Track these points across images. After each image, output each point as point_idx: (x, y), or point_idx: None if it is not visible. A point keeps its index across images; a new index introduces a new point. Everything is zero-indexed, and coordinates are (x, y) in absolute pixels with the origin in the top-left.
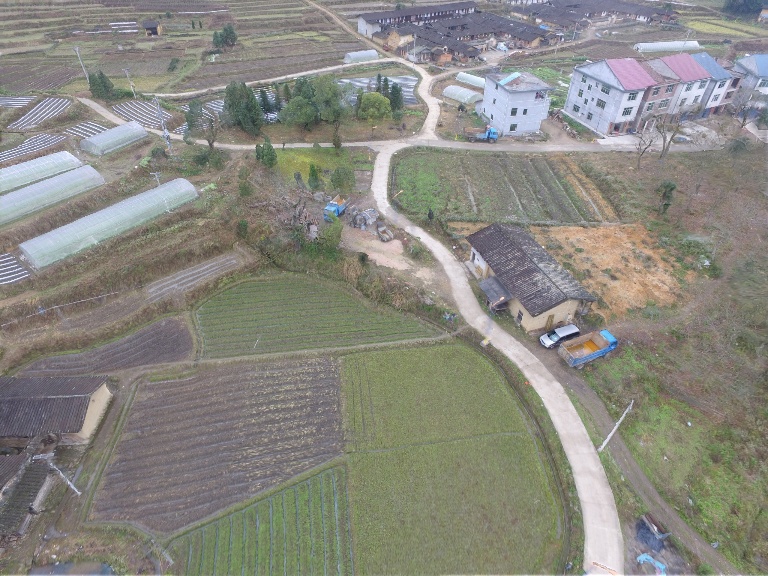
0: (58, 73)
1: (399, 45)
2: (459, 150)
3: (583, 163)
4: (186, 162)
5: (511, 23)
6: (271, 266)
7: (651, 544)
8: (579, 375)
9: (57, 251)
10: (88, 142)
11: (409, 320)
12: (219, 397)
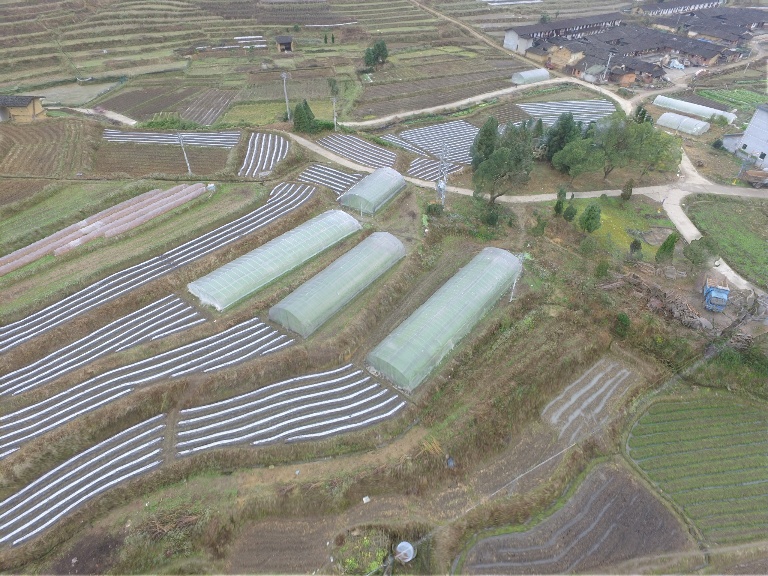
0: (209, 96)
1: (568, 63)
2: (751, 199)
3: None
4: (469, 221)
5: (671, 37)
6: (675, 378)
7: None
8: None
9: (425, 365)
10: (358, 197)
11: None
12: None
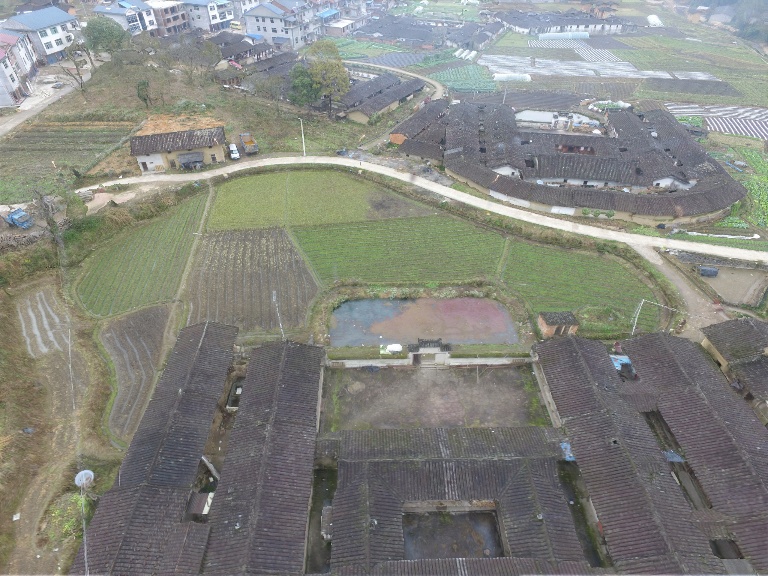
0: None
1: None
2: None
3: (52, 119)
4: None
5: None
6: None
7: (346, 153)
8: (261, 154)
9: None
10: None
11: (187, 203)
12: (220, 284)
